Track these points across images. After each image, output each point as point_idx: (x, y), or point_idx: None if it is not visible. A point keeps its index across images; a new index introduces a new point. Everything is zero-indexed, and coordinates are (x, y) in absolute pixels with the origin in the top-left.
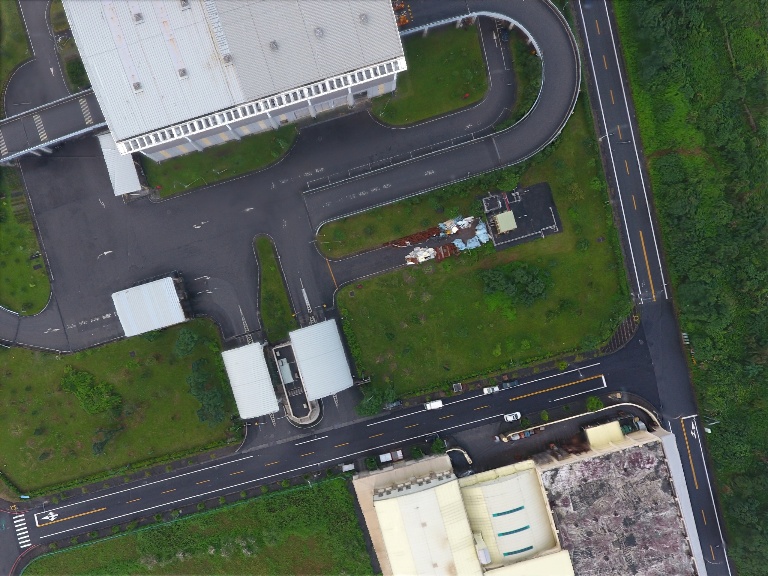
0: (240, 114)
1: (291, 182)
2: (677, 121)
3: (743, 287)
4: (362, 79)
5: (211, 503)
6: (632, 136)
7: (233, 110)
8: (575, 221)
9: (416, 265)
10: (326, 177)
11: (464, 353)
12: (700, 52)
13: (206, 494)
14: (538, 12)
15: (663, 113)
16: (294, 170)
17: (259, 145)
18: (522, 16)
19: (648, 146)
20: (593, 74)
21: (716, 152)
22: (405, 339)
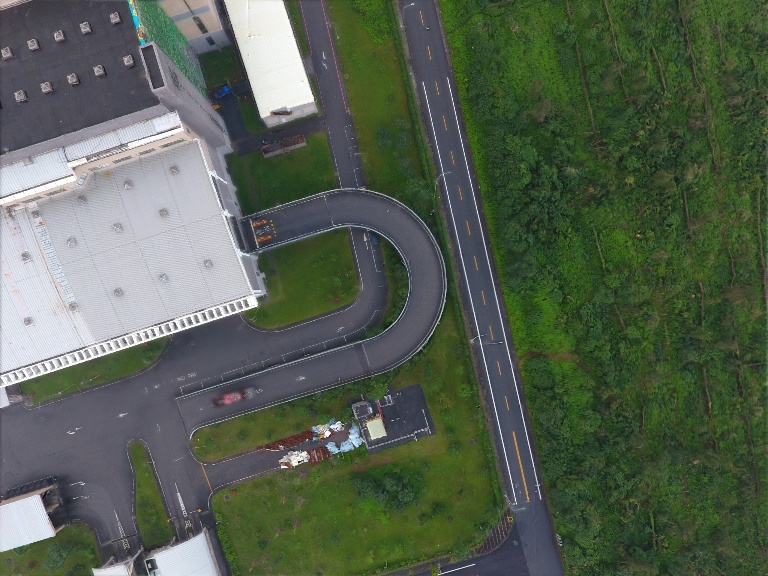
0: (91, 354)
1: (164, 387)
2: (546, 326)
3: (610, 497)
4: (213, 316)
5: None
6: (504, 336)
7: (84, 350)
8: (448, 423)
9: (290, 469)
10: (199, 382)
11: (339, 556)
12: (569, 254)
13: None
14: (403, 222)
15: (531, 319)
16: (167, 375)
17: (131, 351)
18: (387, 226)
19: (519, 348)
20: (464, 275)
21: (587, 353)
22: (280, 543)
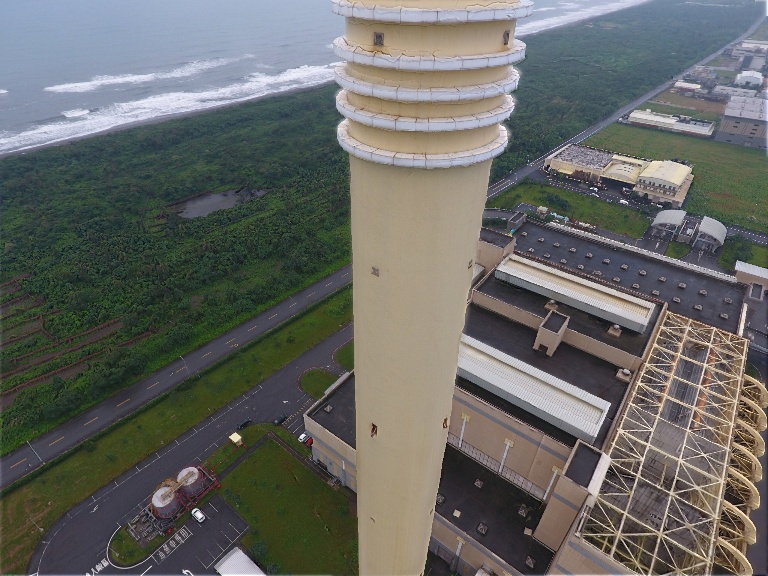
0: None
1: None
2: None
3: None
4: None
5: (765, 235)
6: None
7: None
8: None
9: None
10: None
11: None
12: None
13: (766, 238)
14: None
15: None
16: None
17: None
18: None
19: None
20: None
21: None
22: None
